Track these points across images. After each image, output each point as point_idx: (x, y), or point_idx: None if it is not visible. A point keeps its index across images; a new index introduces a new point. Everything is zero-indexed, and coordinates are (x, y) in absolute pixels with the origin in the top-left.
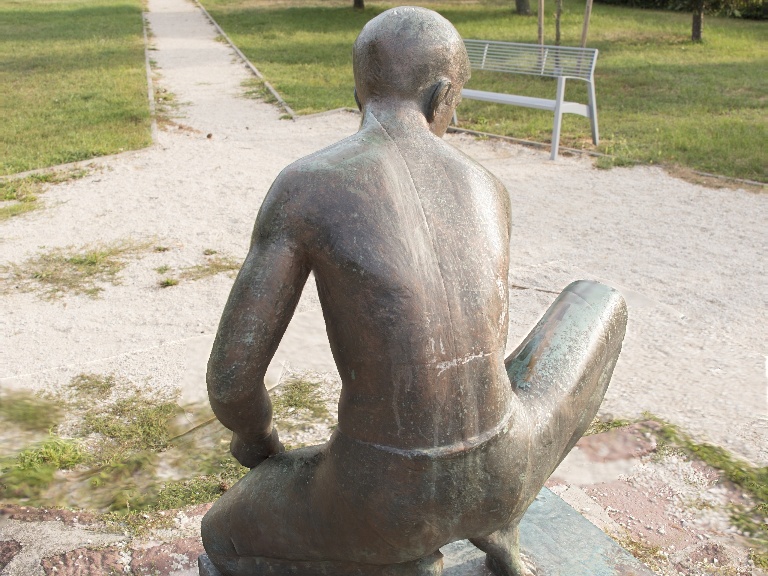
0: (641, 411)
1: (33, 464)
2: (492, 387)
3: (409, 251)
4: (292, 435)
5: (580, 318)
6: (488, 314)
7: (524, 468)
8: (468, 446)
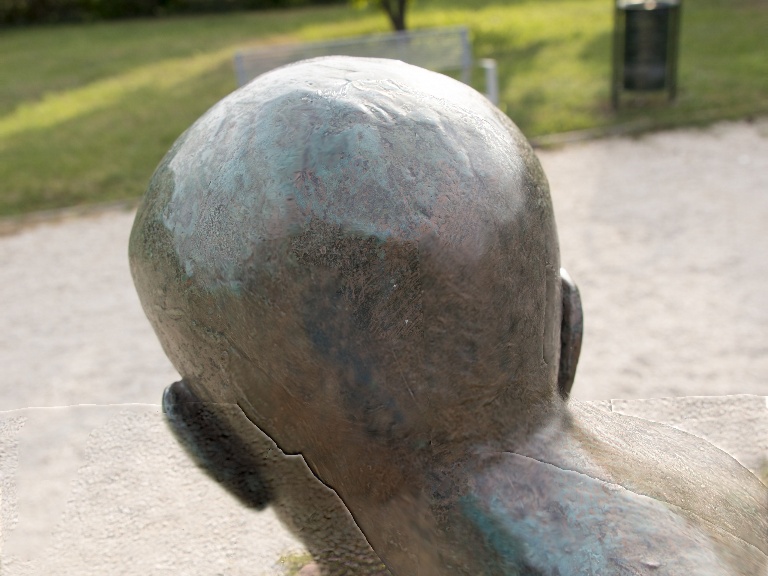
0: (272, 561)
1: None
2: None
3: None
4: None
5: None
6: None
7: None
8: None
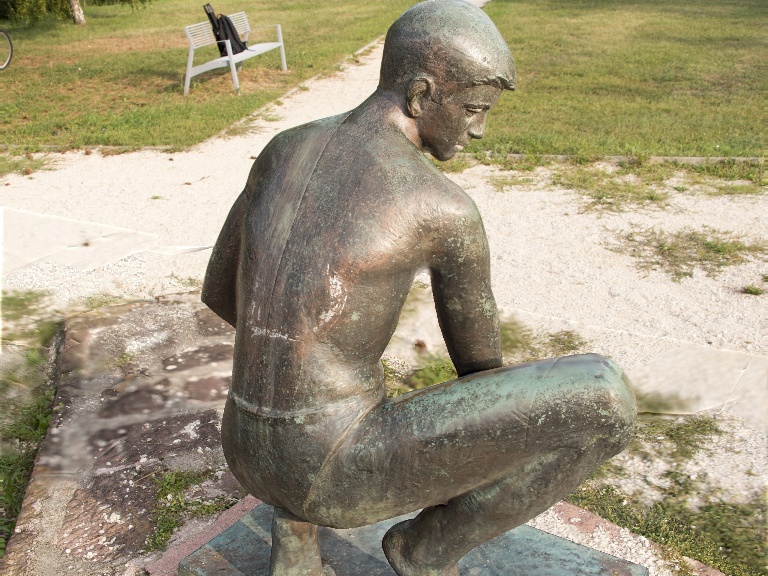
0: None
1: (441, 370)
2: (290, 372)
3: (271, 221)
4: (627, 456)
5: (513, 381)
6: (305, 303)
7: (316, 470)
8: (259, 412)
